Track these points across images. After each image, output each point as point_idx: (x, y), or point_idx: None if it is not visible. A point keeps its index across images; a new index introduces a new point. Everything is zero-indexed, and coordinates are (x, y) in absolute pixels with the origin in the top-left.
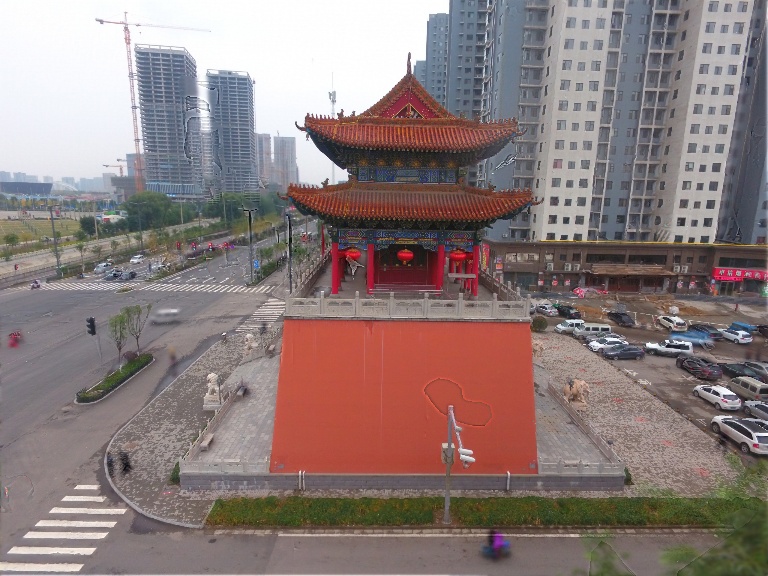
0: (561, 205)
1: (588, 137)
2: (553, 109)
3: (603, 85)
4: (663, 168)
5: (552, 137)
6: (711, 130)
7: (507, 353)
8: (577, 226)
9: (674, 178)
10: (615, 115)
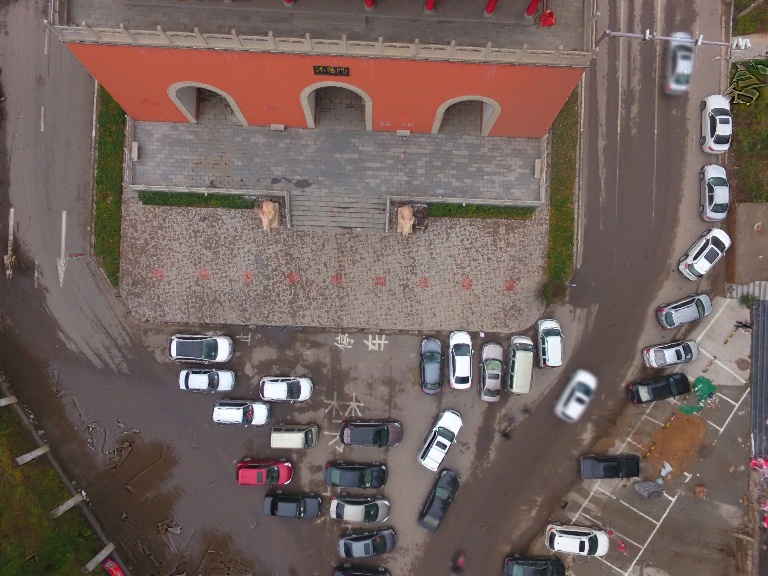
0: None
1: None
2: None
3: None
4: None
5: None
6: None
7: None
8: None
9: None
10: None
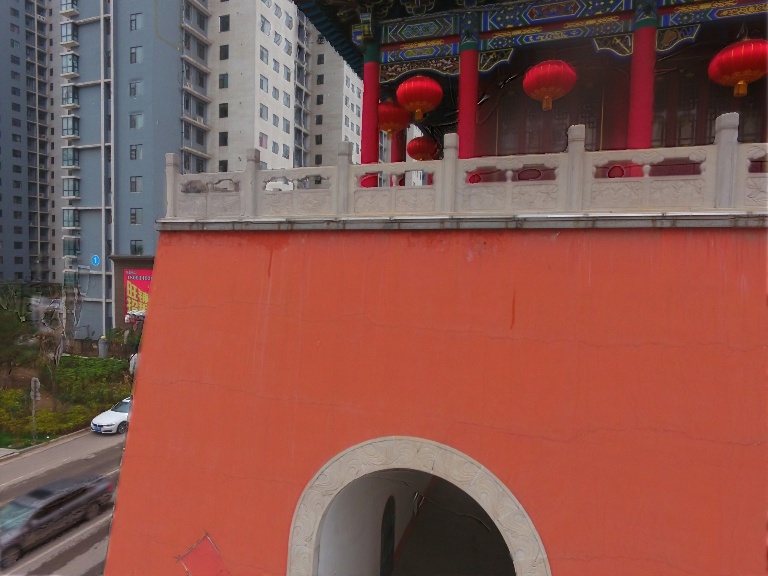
0: None
1: (286, 114)
2: (256, 53)
3: (296, 50)
4: None
5: (256, 96)
6: None
7: None
8: None
9: None
10: None
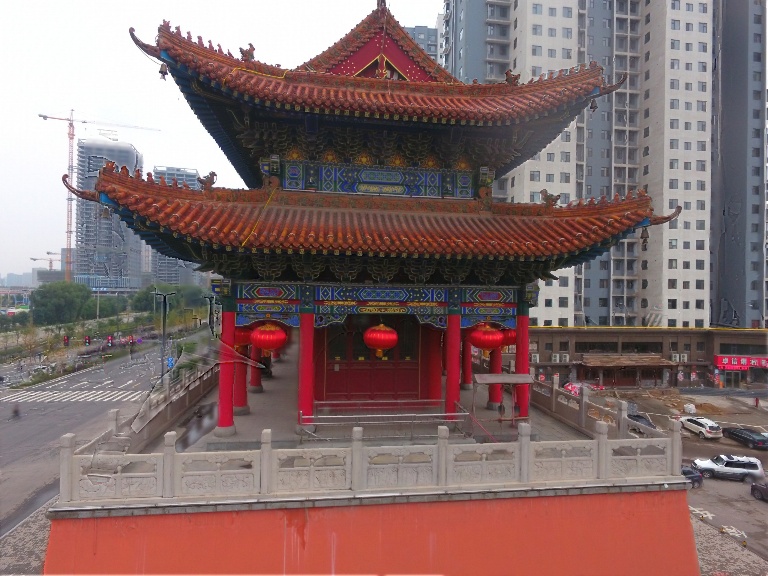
0: (541, 285)
1: None
2: (524, 179)
3: (575, 156)
4: (643, 246)
5: None
6: (689, 206)
7: (641, 571)
8: (561, 309)
9: (658, 256)
10: (586, 190)
